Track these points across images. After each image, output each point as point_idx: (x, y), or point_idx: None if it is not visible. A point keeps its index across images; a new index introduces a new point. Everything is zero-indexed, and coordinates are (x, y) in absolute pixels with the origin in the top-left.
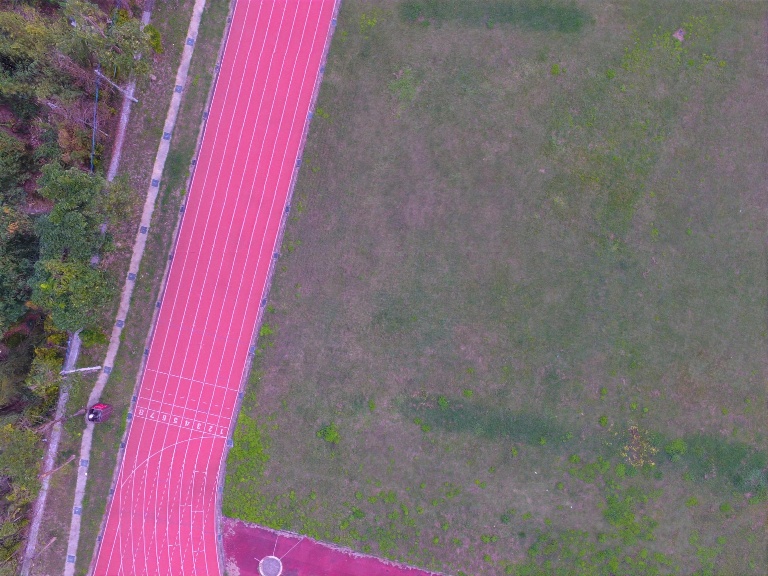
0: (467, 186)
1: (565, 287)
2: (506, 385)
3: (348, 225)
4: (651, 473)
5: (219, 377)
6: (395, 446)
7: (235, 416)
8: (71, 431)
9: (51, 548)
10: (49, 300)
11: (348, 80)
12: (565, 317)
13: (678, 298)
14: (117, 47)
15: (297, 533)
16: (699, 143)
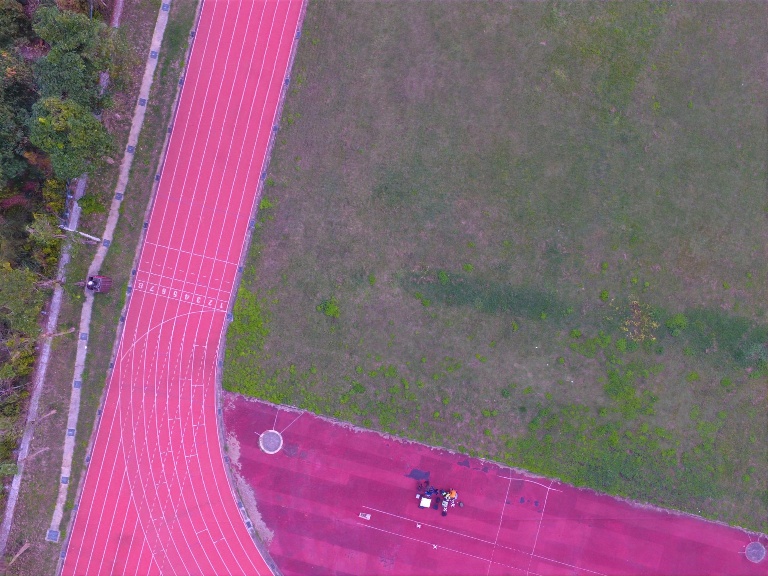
0: (468, 59)
1: (566, 161)
2: (507, 259)
3: (348, 98)
4: (652, 348)
5: (219, 251)
6: (395, 320)
7: (235, 290)
8: (70, 292)
9: (51, 421)
10: (47, 139)
11: None
12: (566, 191)
13: (679, 172)
14: None
15: (297, 407)
16: (701, 15)
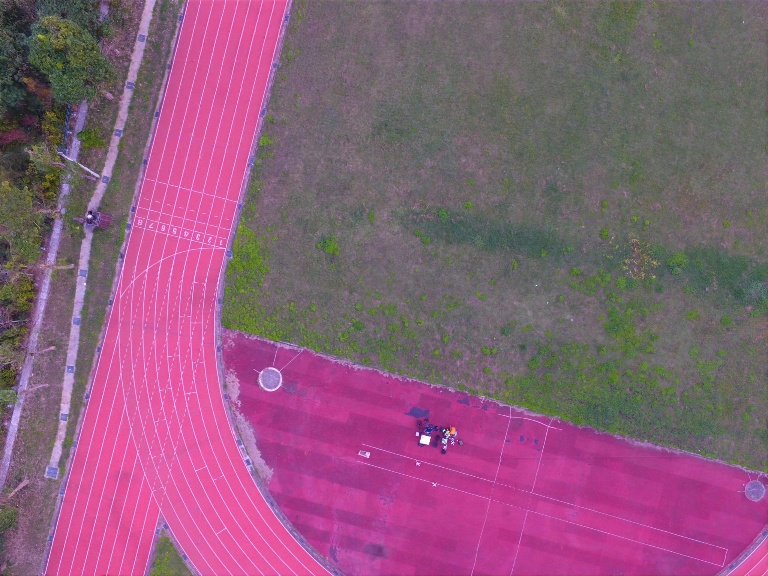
0: None
1: (566, 98)
2: (507, 197)
3: (348, 34)
4: (652, 286)
5: (218, 187)
6: (395, 258)
7: (234, 227)
8: (69, 223)
9: (50, 358)
10: (46, 58)
11: None
12: (566, 129)
13: (680, 110)
14: None
15: (297, 345)
16: None
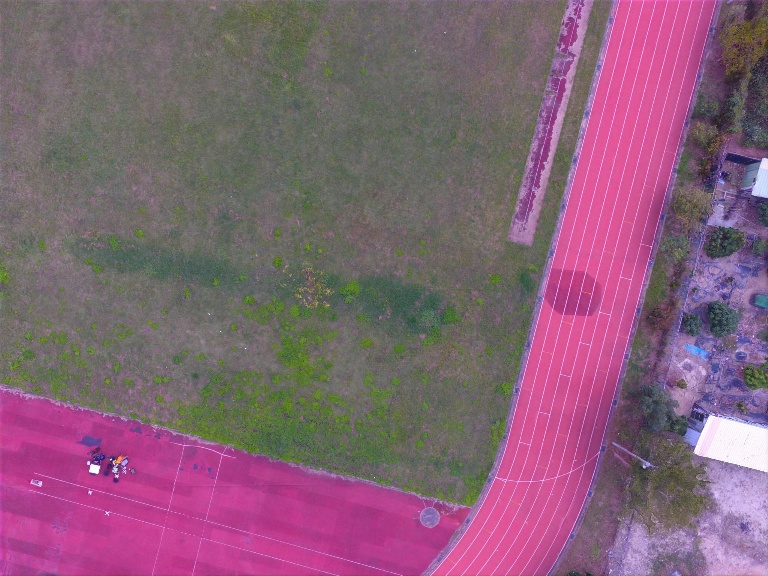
0: (136, 23)
1: (238, 127)
2: (179, 226)
3: (14, 62)
4: (326, 314)
5: None
6: (66, 287)
7: None
8: None
9: None
10: None
11: None
12: (238, 157)
13: (353, 139)
14: None
15: None
16: None
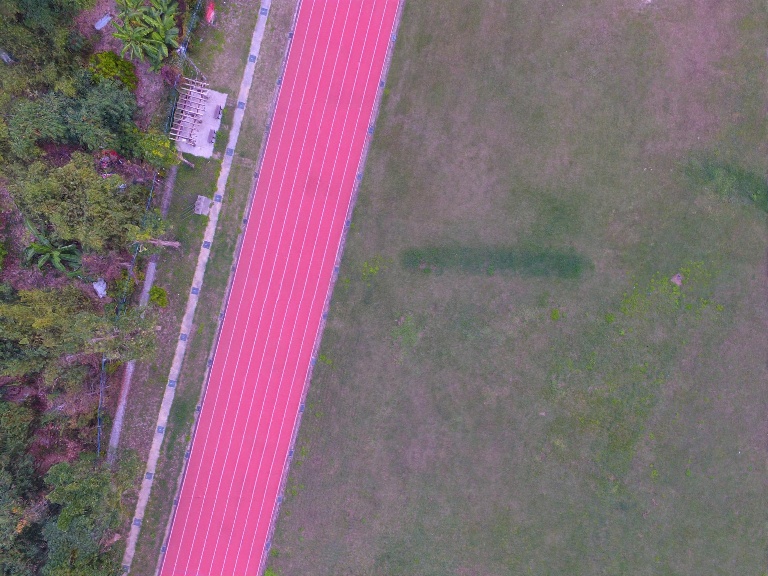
0: (468, 430)
1: (566, 529)
2: None
3: (351, 469)
4: None
5: None
6: None
7: None
8: None
9: None
10: None
11: (350, 326)
12: (566, 558)
13: (678, 538)
14: (124, 346)
15: None
16: (698, 385)
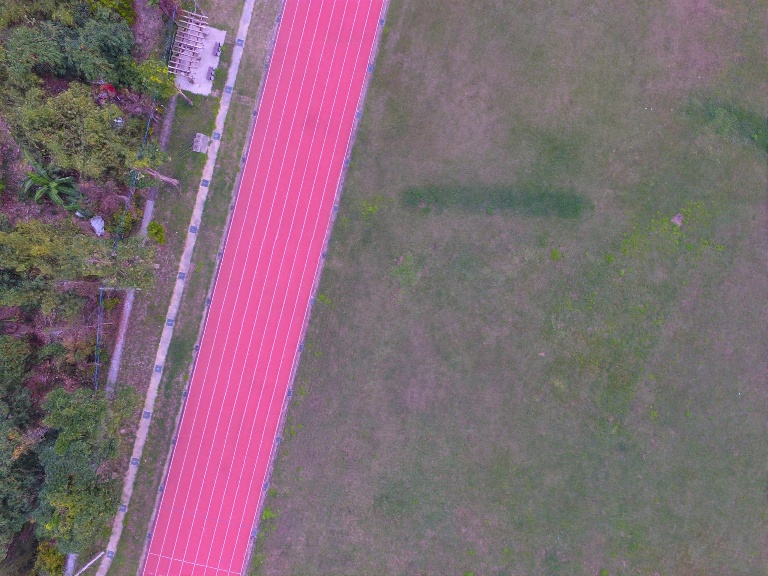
0: (467, 370)
1: (565, 469)
2: (507, 567)
3: (349, 409)
4: None
5: (221, 561)
6: None
7: None
8: None
9: None
10: (54, 533)
11: (349, 266)
12: (565, 499)
13: (677, 480)
14: (121, 272)
15: None
16: (698, 326)
